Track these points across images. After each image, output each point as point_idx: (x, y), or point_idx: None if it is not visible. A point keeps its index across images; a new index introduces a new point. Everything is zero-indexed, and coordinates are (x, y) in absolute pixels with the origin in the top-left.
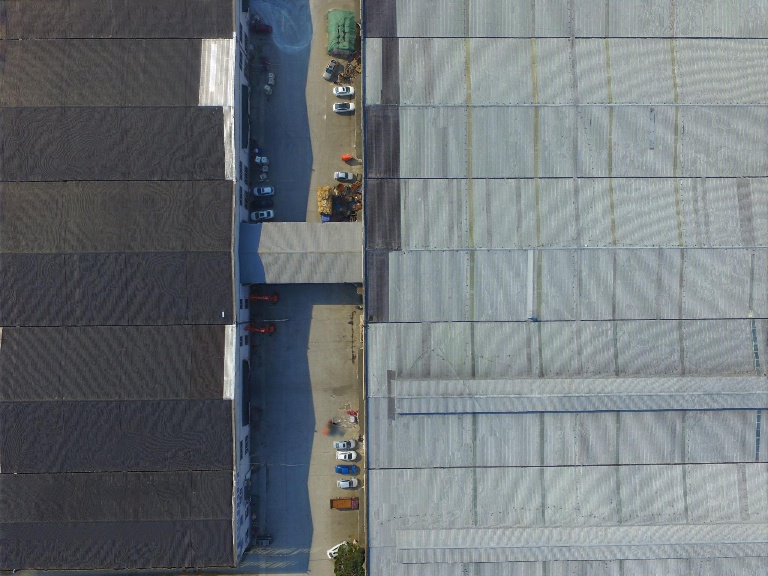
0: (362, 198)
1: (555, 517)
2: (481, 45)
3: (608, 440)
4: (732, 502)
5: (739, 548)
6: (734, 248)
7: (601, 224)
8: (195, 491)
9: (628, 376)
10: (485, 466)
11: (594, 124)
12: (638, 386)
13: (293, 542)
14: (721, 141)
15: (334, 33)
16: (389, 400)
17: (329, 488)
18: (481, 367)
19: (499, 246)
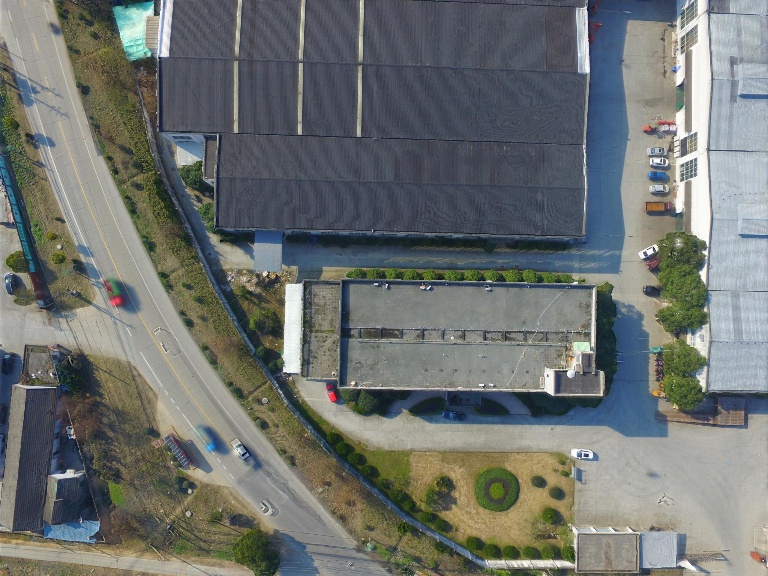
0: None
1: None
2: None
3: None
4: None
5: None
6: None
7: None
8: (547, 162)
9: None
10: None
11: None
12: None
13: (606, 244)
14: None
15: None
16: (732, 83)
17: (640, 194)
18: None
19: None
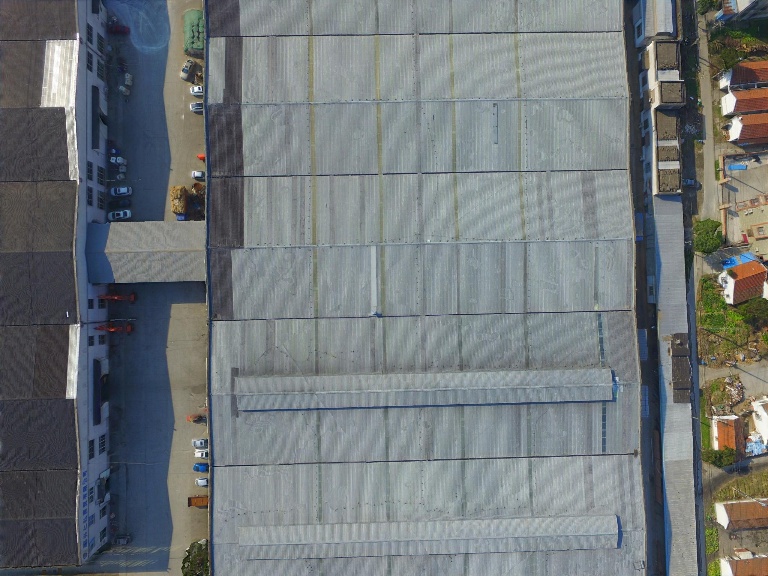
0: (205, 196)
1: (400, 512)
2: (325, 43)
3: (453, 434)
4: (578, 495)
5: (582, 540)
6: (577, 241)
7: (444, 219)
8: (40, 490)
9: (471, 370)
10: (330, 462)
11: (437, 120)
12: (480, 380)
13: (153, 540)
14: (565, 135)
15: (188, 33)
16: (232, 397)
17: (189, 486)
18: (325, 363)
19: (341, 242)
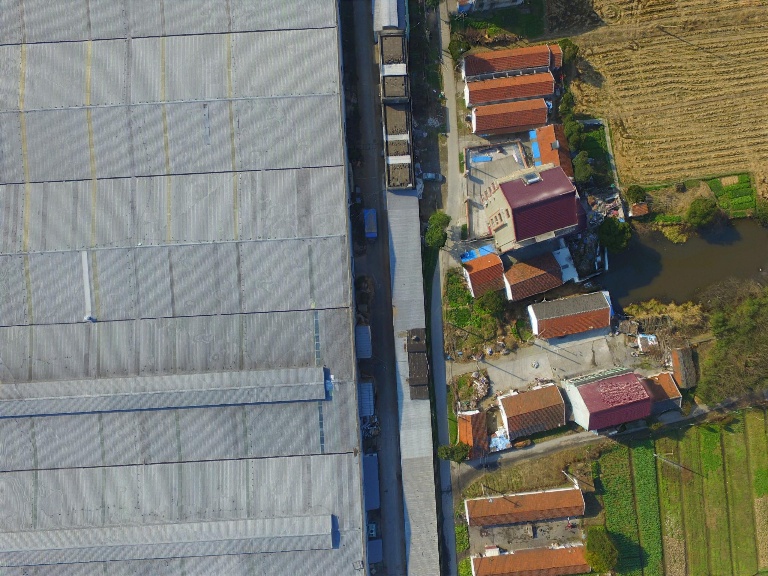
0: None
1: (115, 517)
2: (37, 50)
3: (169, 438)
4: (295, 495)
5: (296, 541)
6: (290, 240)
7: (156, 222)
8: None
9: (182, 373)
10: (47, 468)
11: (148, 123)
12: (190, 382)
13: None
14: (278, 133)
15: None
16: None
17: None
18: (38, 370)
19: (52, 249)
